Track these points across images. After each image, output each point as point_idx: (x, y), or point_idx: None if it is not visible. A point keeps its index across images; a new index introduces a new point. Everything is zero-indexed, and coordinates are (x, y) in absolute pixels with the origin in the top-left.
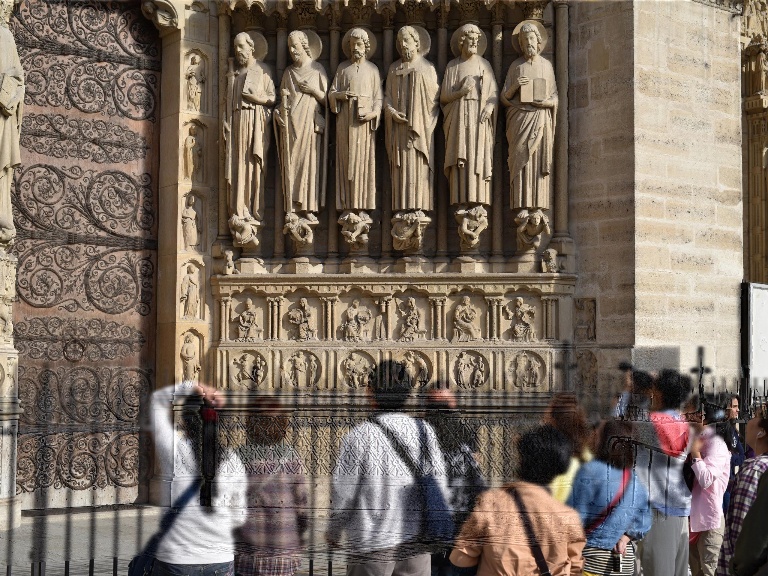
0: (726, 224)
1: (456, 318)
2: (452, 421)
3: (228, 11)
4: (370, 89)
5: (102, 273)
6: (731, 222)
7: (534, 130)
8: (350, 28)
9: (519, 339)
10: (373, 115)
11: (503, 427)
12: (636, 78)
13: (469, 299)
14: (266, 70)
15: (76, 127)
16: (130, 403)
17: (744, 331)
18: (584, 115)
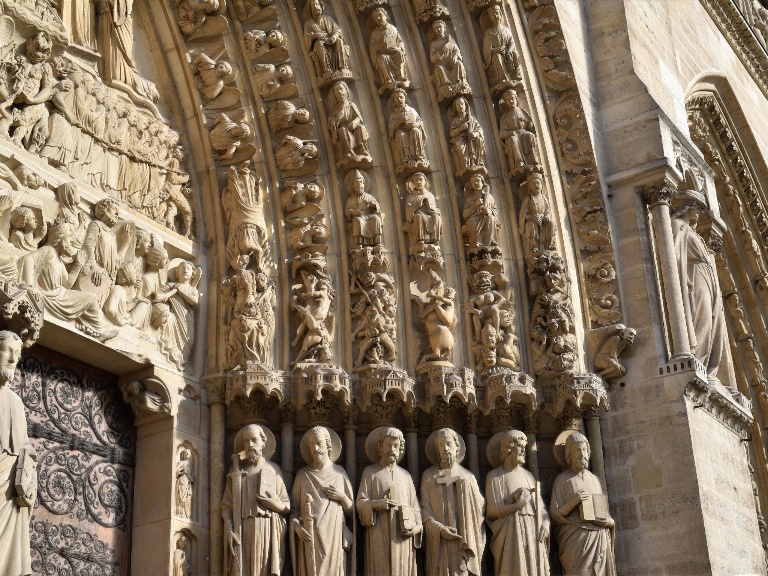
0: None
1: None
2: None
3: (226, 399)
4: (407, 498)
5: None
6: None
7: (600, 552)
8: (367, 428)
9: None
10: (419, 529)
11: None
12: (701, 497)
13: None
14: (278, 471)
15: (42, 532)
16: None
17: None
18: (634, 538)
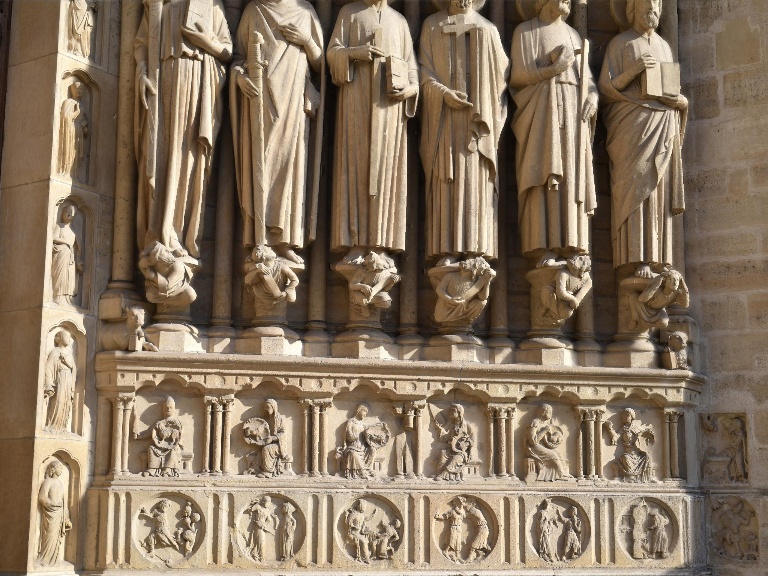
0: None
1: (533, 441)
2: None
3: None
4: (399, 50)
5: None
6: None
7: (665, 140)
8: None
9: (632, 478)
10: (413, 90)
11: None
12: None
13: (551, 409)
14: (217, 0)
15: None
16: None
17: None
18: (711, 130)
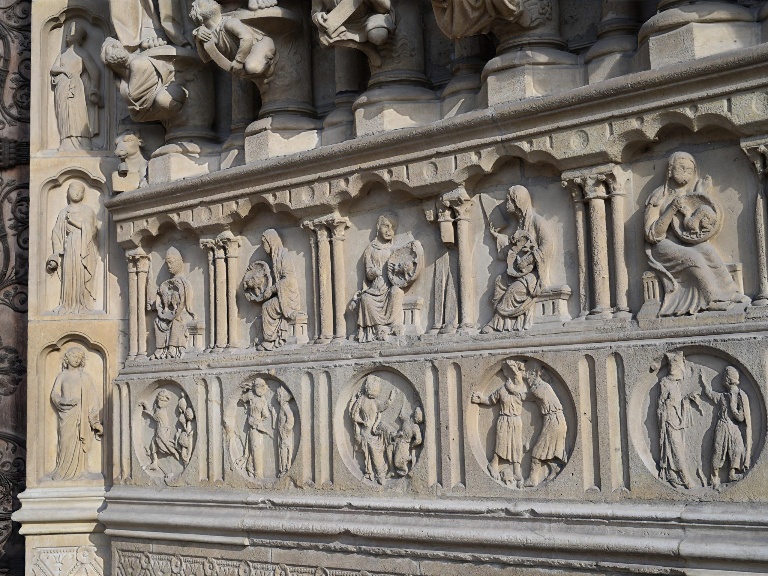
0: None
1: (645, 234)
2: None
3: None
4: None
5: None
6: None
7: None
8: None
9: None
10: None
11: None
12: None
13: (688, 161)
14: None
15: None
16: None
17: None
18: None
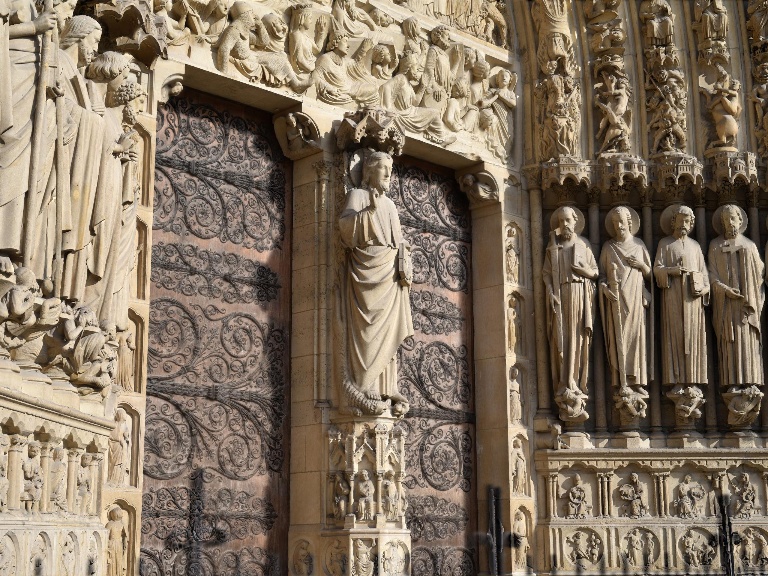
0: None
1: None
2: None
3: (543, 185)
4: (697, 265)
5: (433, 448)
6: None
7: None
8: (661, 205)
9: None
10: (707, 290)
11: None
12: None
13: None
14: (588, 244)
15: None
16: None
17: None
18: None
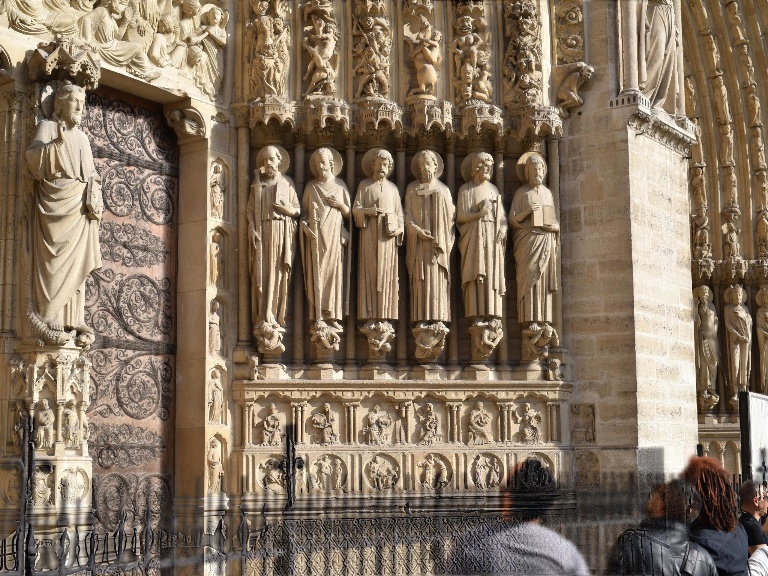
0: (685, 338)
1: (472, 422)
2: (471, 520)
3: (250, 124)
4: (393, 206)
5: (130, 378)
6: (688, 337)
7: (545, 251)
8: (365, 148)
9: (528, 442)
10: (400, 231)
11: (518, 524)
12: (632, 209)
13: (482, 404)
14: (291, 183)
15: (109, 230)
16: (153, 510)
17: (745, 434)
18: (577, 239)
